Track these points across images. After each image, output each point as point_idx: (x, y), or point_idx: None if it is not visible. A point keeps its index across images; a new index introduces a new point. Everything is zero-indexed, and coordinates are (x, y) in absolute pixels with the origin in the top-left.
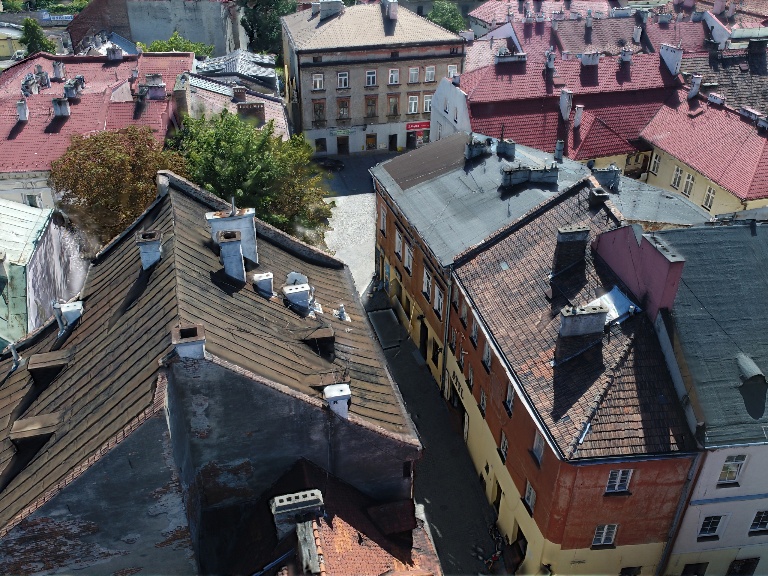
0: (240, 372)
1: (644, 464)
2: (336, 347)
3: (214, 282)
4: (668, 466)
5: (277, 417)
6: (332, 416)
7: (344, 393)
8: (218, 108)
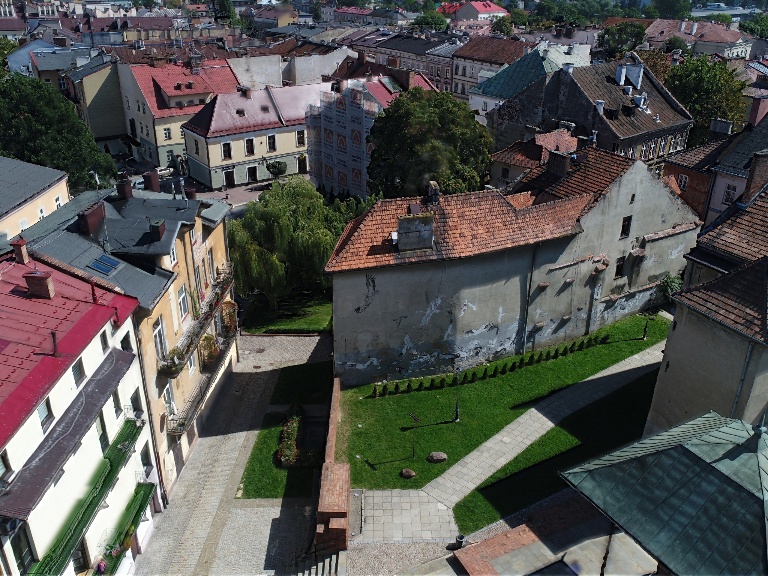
0: (576, 81)
1: (692, 175)
2: (635, 117)
3: (606, 77)
4: (701, 180)
5: (581, 104)
6: (596, 110)
7: (601, 101)
8: (750, 76)
